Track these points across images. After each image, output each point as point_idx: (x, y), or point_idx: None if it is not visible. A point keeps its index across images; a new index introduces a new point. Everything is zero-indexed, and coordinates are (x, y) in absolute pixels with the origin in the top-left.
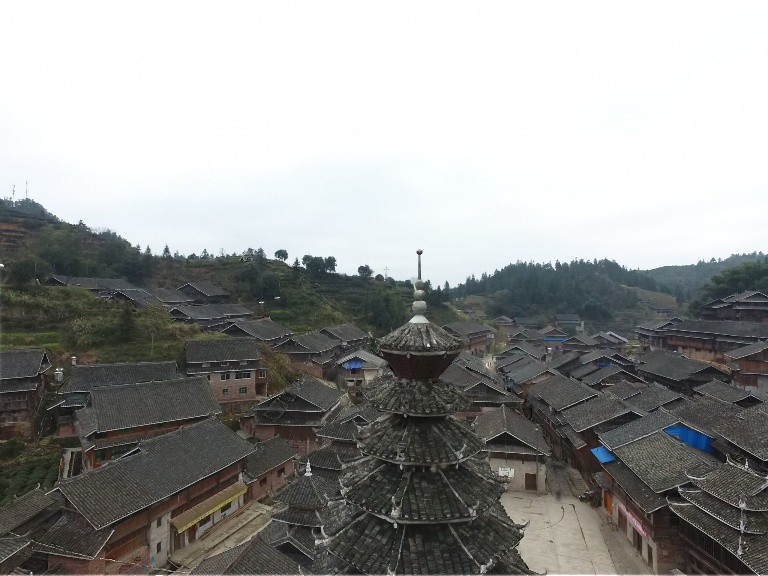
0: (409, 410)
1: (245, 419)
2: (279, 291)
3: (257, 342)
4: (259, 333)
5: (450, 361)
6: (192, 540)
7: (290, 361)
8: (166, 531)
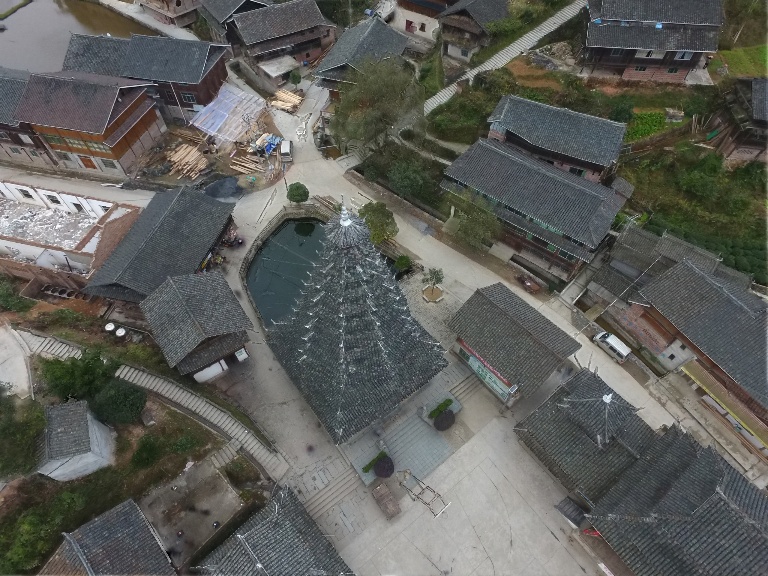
0: None
1: None
2: None
3: None
4: None
5: None
6: (700, 394)
7: None
8: (684, 358)
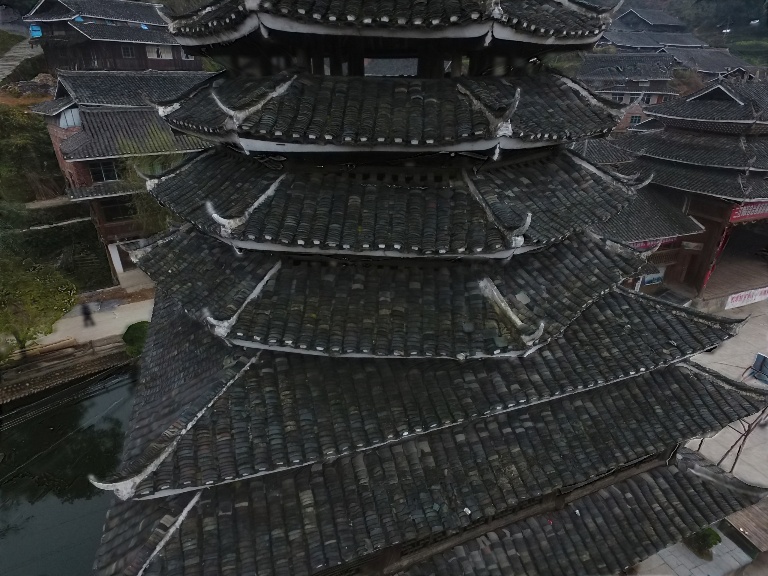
0: None
1: None
2: (762, 11)
3: None
4: None
5: None
6: None
7: None
8: None
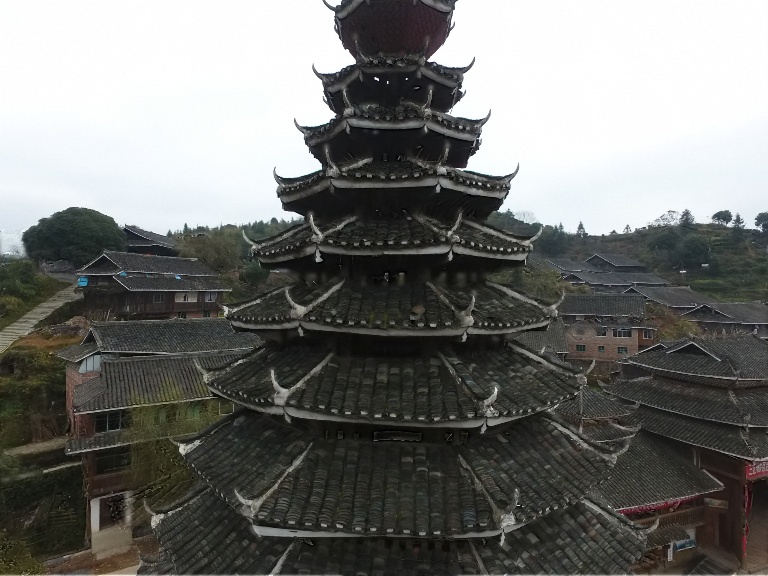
0: (326, 84)
1: (614, 376)
2: (709, 257)
3: (654, 305)
4: (664, 299)
5: (403, 18)
6: None
7: (700, 330)
8: None
